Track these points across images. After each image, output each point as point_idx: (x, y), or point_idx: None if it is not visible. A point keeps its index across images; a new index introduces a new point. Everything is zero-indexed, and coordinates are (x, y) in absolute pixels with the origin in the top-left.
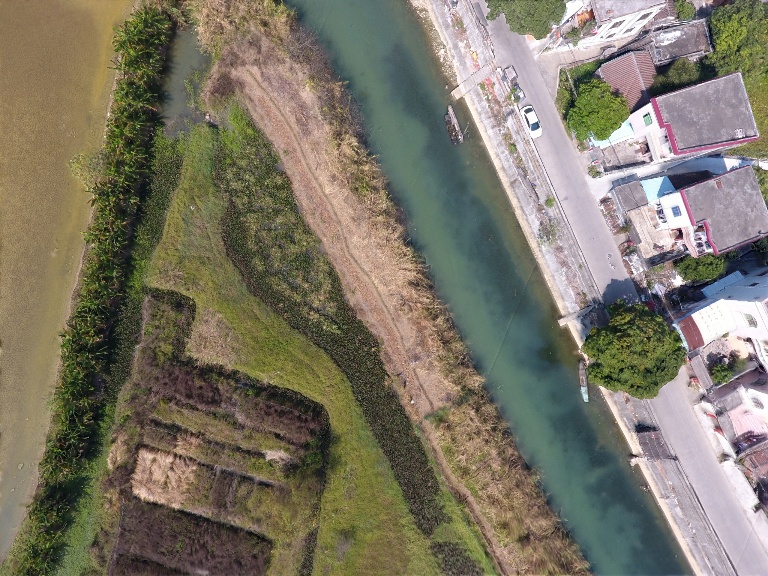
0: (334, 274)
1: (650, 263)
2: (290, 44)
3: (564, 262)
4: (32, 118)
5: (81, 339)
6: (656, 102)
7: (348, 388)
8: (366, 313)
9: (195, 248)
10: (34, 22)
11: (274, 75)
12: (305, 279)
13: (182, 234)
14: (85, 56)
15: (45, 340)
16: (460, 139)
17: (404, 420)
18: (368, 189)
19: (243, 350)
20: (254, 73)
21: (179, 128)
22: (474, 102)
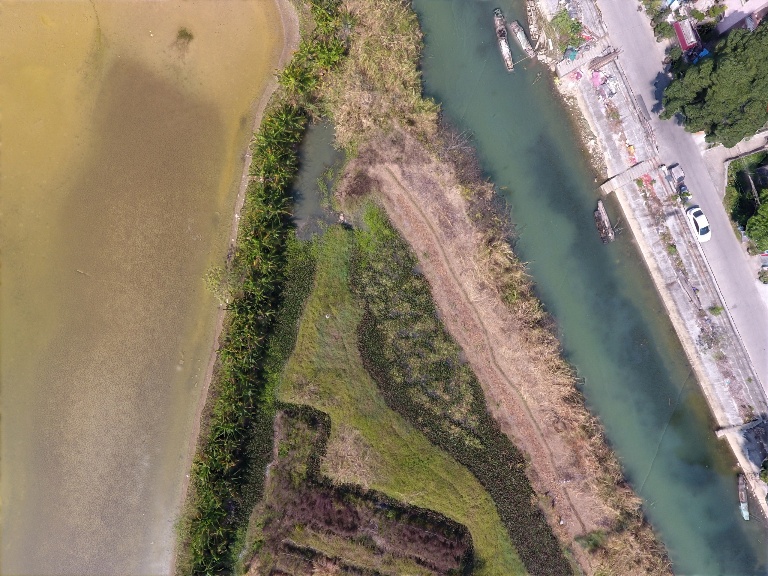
0: (476, 385)
1: None
2: (434, 140)
3: (728, 372)
4: (156, 221)
5: (217, 466)
6: None
7: (493, 508)
8: (511, 427)
9: (330, 360)
10: (157, 118)
11: (417, 174)
12: (446, 390)
13: (317, 345)
14: (211, 153)
15: (170, 458)
16: (611, 237)
17: (552, 541)
18: (519, 297)
19: (382, 469)
20: (393, 171)
21: (312, 230)
22: (627, 197)
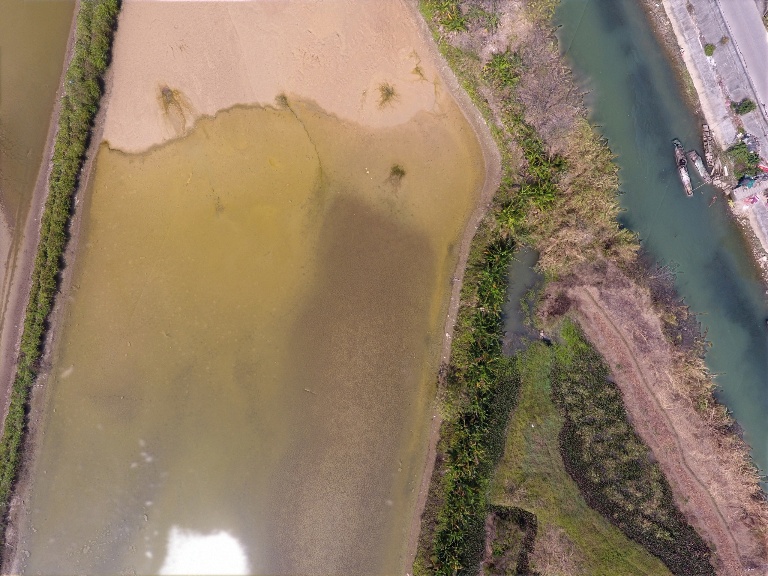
0: (665, 482)
1: None
2: (629, 265)
3: None
4: (374, 342)
5: None
6: None
7: None
8: (698, 520)
9: (537, 465)
10: (374, 247)
11: (615, 296)
12: (638, 488)
13: (525, 452)
14: (422, 278)
15: (391, 558)
16: None
17: None
18: (710, 406)
19: (584, 563)
20: (591, 292)
21: (516, 346)
22: None
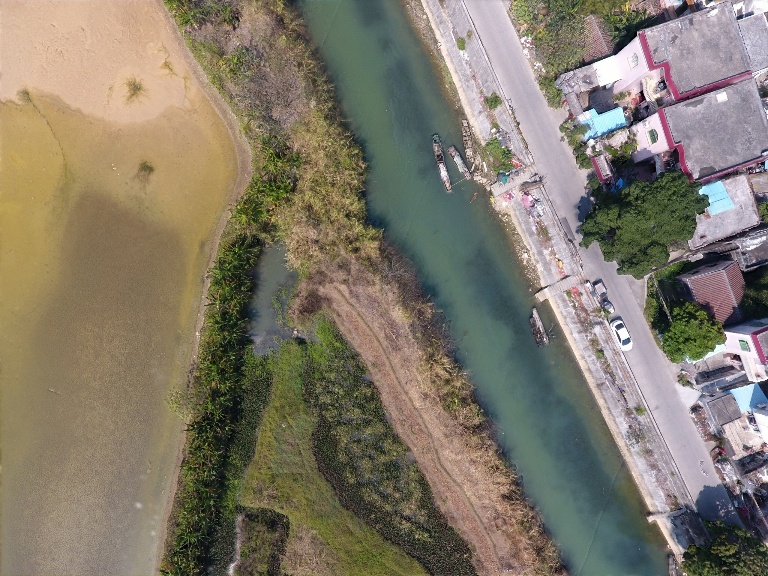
0: (424, 482)
1: (740, 465)
2: (378, 262)
3: (654, 465)
4: (122, 341)
5: (182, 573)
6: (757, 339)
7: None
8: (458, 521)
9: (288, 466)
10: (121, 245)
11: (363, 294)
12: (396, 489)
13: (274, 453)
14: (172, 276)
15: (140, 561)
16: (545, 341)
17: None
18: (460, 405)
19: (338, 565)
20: (342, 290)
21: (268, 345)
22: (559, 306)
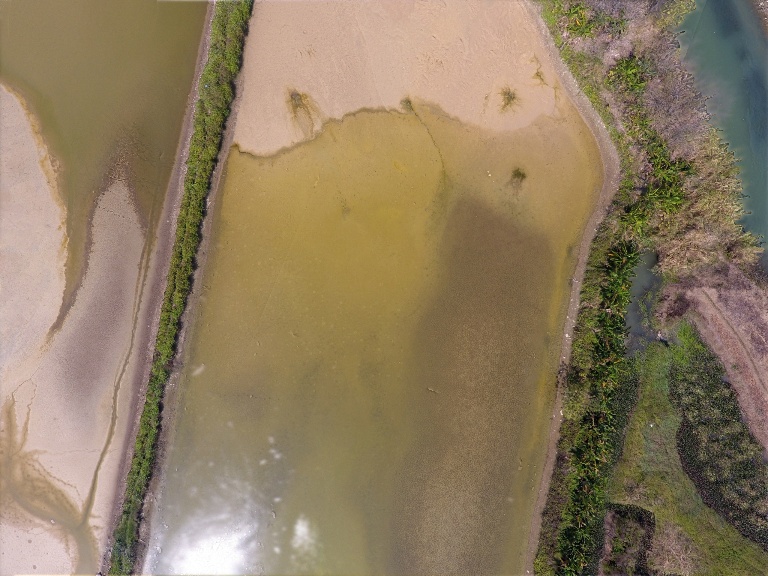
0: None
1: None
2: (748, 267)
3: None
4: (496, 342)
5: None
6: None
7: None
8: None
9: (655, 464)
10: (495, 249)
11: (734, 298)
12: (752, 487)
13: (644, 451)
14: (542, 279)
15: (512, 555)
16: None
17: None
18: None
19: (702, 561)
20: (709, 294)
21: (634, 347)
22: None
